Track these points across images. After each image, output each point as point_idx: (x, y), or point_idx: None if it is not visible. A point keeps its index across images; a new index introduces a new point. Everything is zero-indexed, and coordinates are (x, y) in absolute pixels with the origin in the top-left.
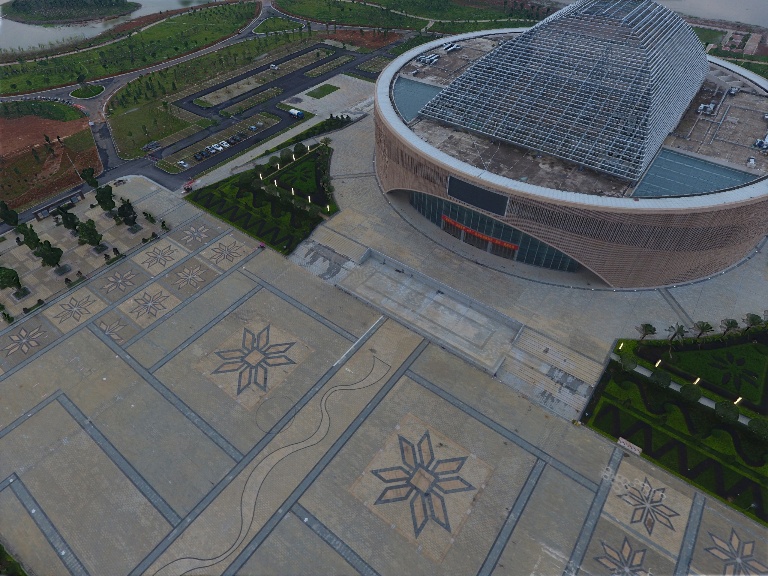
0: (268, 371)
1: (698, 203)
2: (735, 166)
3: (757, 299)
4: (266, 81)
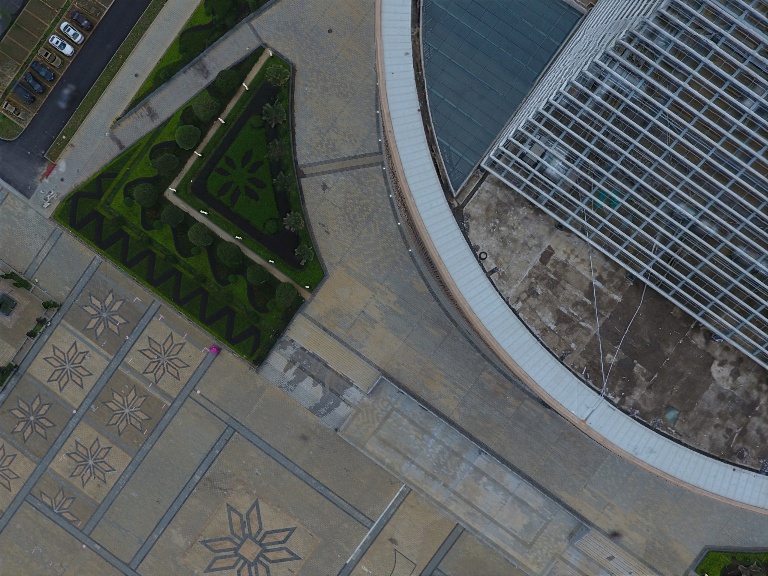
0: (270, 570)
1: None
2: None
3: None
4: None
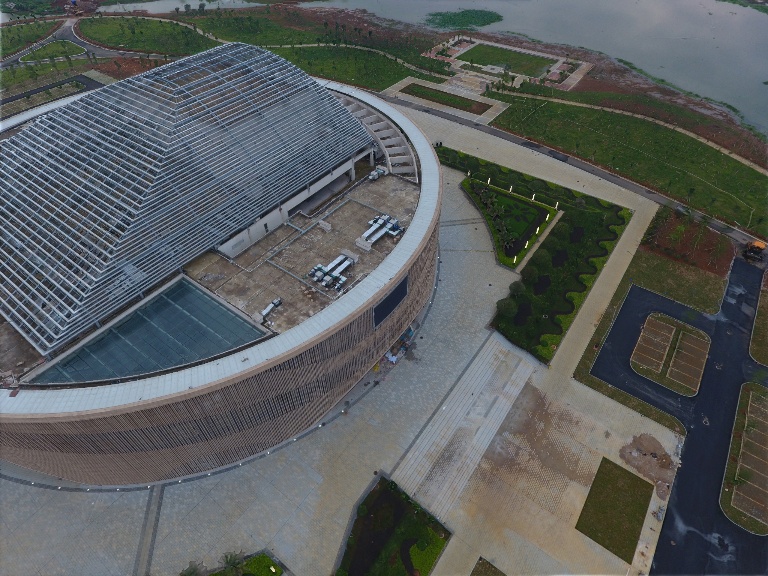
0: None
1: (98, 401)
2: (243, 316)
3: (278, 507)
4: None
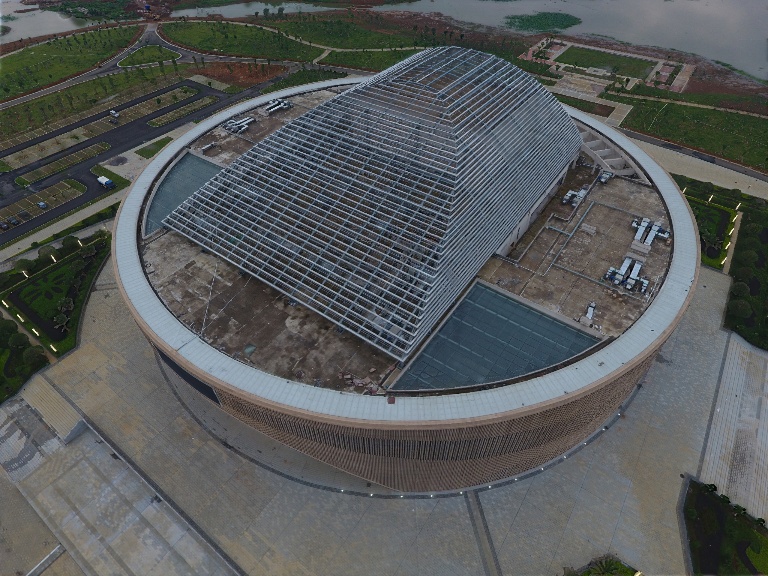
0: None
1: (482, 407)
2: (566, 320)
3: (601, 511)
4: (96, 133)
